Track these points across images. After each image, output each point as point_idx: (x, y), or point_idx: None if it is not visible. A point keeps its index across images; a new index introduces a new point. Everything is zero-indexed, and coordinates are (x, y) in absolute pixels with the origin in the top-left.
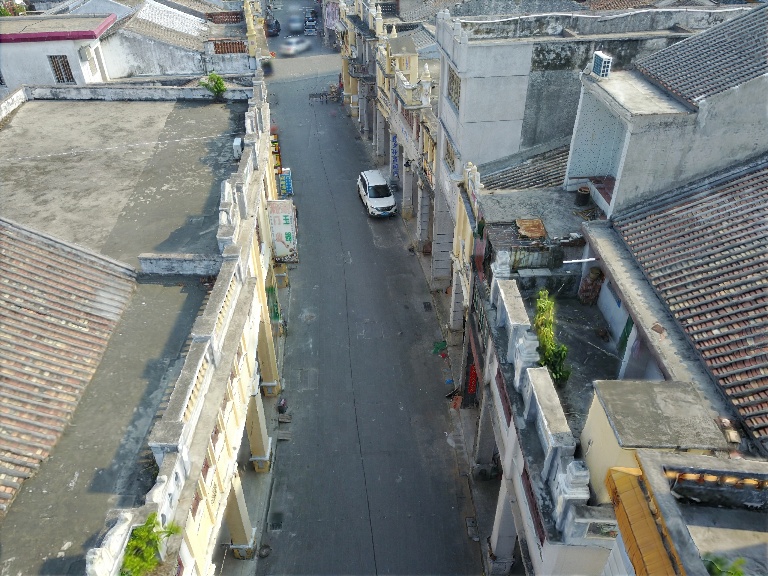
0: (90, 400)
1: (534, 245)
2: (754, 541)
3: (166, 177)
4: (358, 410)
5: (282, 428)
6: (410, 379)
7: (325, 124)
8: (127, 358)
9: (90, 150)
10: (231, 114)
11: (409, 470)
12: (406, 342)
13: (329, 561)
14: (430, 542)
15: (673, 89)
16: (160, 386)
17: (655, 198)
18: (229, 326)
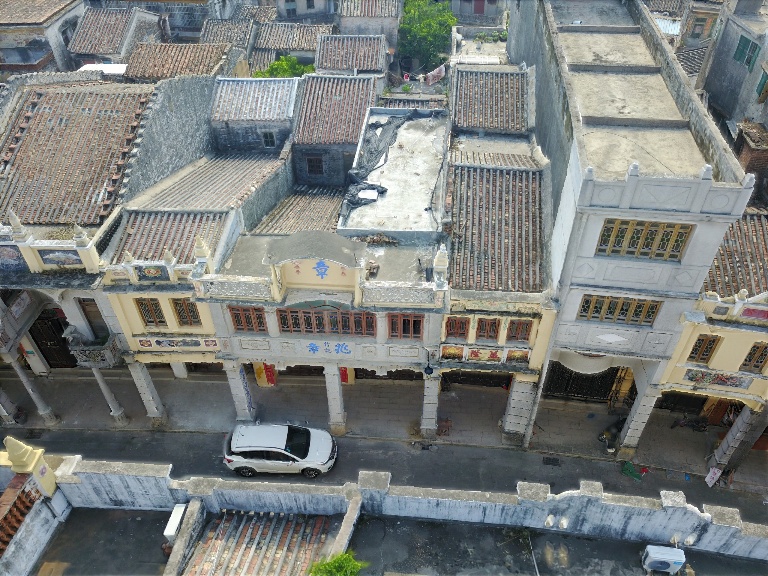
0: None
1: None
2: None
3: None
4: None
5: None
6: None
7: None
8: None
9: None
10: (420, 571)
11: None
12: None
13: None
14: None
15: None
16: None
17: None
18: None
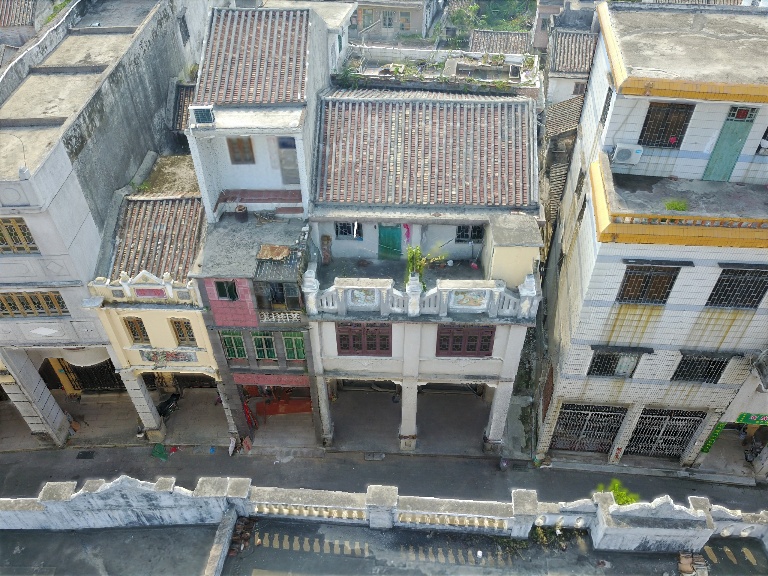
0: None
1: None
2: None
3: None
4: None
5: None
6: None
7: None
8: None
9: None
10: None
11: None
12: None
13: None
14: None
15: (270, 101)
16: (416, 568)
17: (313, 171)
18: None
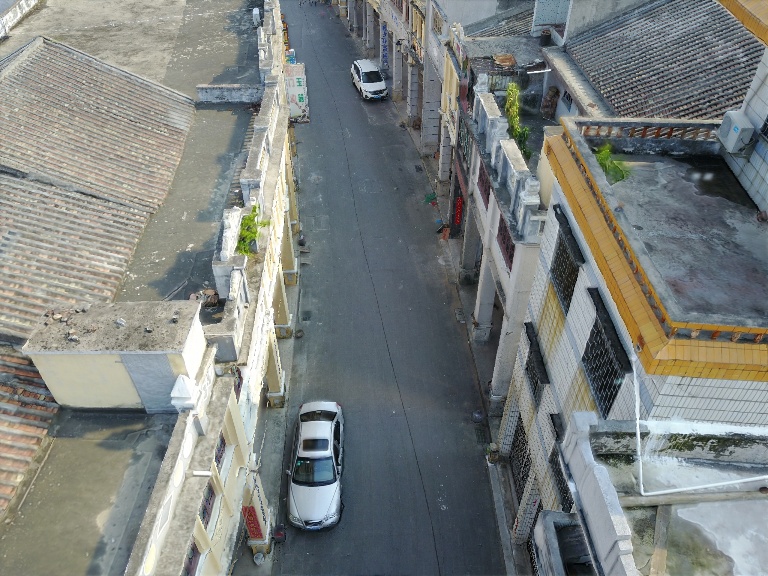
0: (181, 176)
1: (506, 70)
2: (626, 165)
3: (198, 41)
4: (365, 242)
5: (303, 256)
6: (406, 220)
7: (316, 24)
8: (201, 153)
9: (126, 22)
10: None
11: (409, 281)
12: (401, 195)
13: (350, 338)
14: (427, 325)
15: None
16: (231, 168)
17: (598, 26)
18: (274, 134)
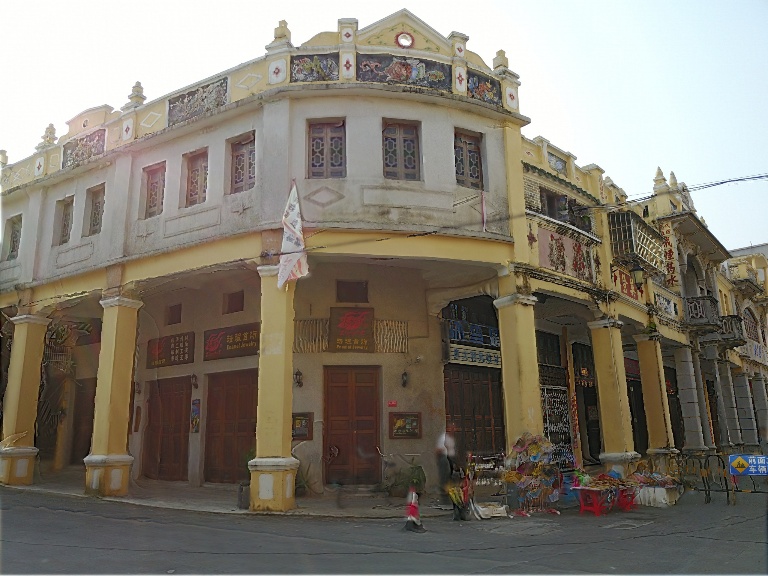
0: None
1: None
2: None
3: None
4: None
5: None
6: None
7: None
8: None
9: None
10: None
11: None
12: None
13: None
14: None
15: None
16: None
17: None
18: None
